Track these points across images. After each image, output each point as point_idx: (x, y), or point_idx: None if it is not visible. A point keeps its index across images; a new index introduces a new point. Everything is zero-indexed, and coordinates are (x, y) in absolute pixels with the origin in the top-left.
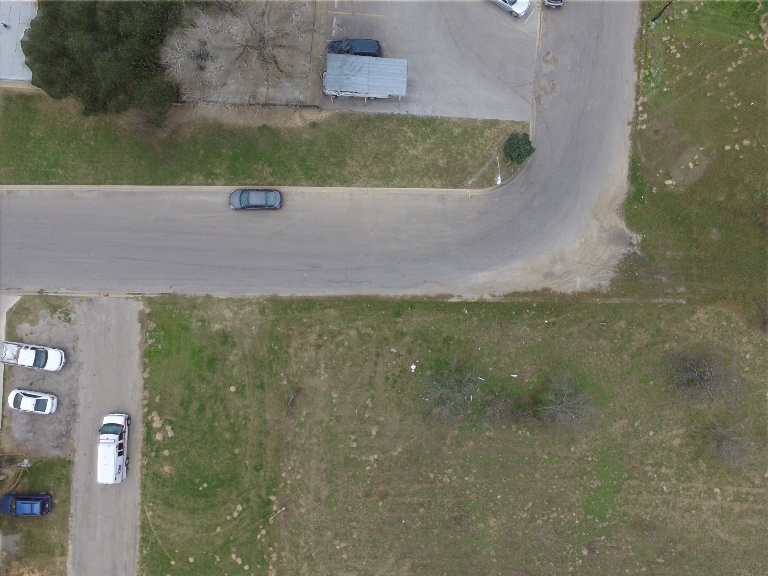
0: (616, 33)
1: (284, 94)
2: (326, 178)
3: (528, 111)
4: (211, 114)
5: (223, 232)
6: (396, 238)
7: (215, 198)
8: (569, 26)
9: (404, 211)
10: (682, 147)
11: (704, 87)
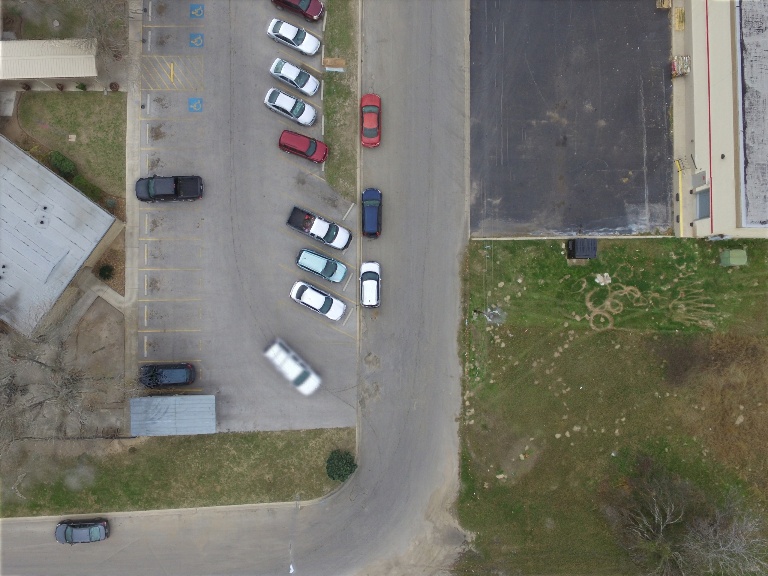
0: (438, 327)
1: (100, 422)
2: (152, 502)
3: (353, 416)
4: (28, 447)
5: (54, 563)
6: (229, 556)
7: (43, 528)
8: (389, 324)
9: (235, 528)
10: (512, 439)
11: (531, 375)
